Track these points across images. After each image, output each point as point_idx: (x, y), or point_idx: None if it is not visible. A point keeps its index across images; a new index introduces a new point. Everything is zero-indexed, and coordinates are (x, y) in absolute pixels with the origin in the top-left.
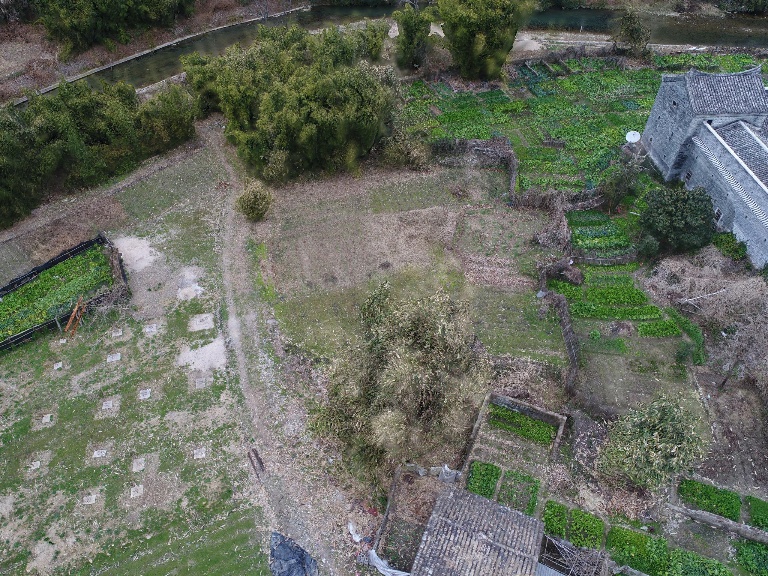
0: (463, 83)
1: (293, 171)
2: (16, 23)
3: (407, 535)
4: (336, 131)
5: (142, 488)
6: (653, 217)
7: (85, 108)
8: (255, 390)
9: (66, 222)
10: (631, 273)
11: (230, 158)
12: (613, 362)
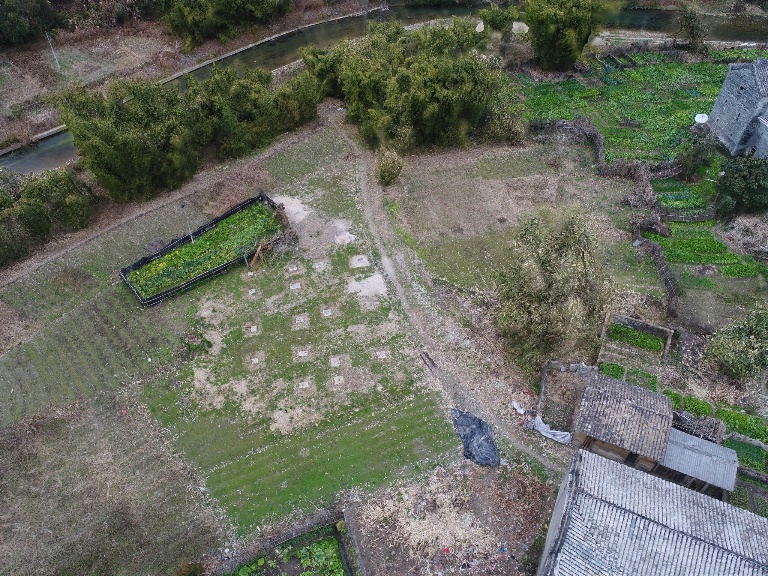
0: (542, 73)
1: (410, 145)
2: (138, 20)
3: (559, 411)
4: (453, 109)
5: (342, 378)
6: (730, 181)
7: (236, 90)
8: (416, 310)
9: (226, 184)
10: (710, 228)
11: (351, 135)
12: (703, 295)
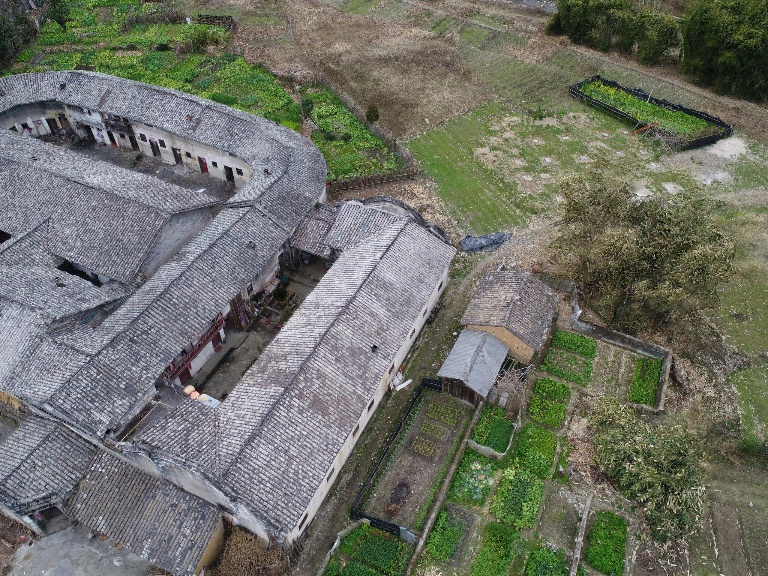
0: None
1: None
2: None
3: None
4: None
5: (530, 179)
6: None
7: None
8: None
9: None
10: None
11: None
12: None
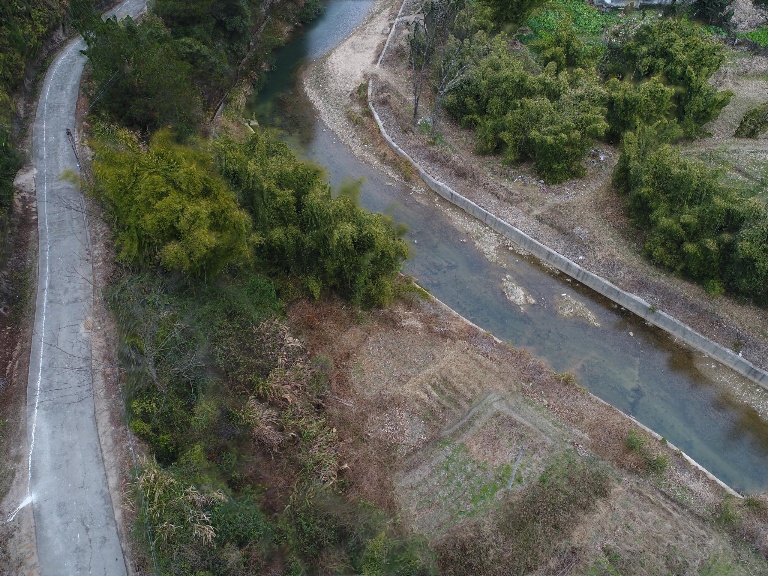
0: None
1: None
2: None
3: None
4: None
5: None
6: (719, 3)
7: None
8: None
9: None
10: None
11: None
12: None
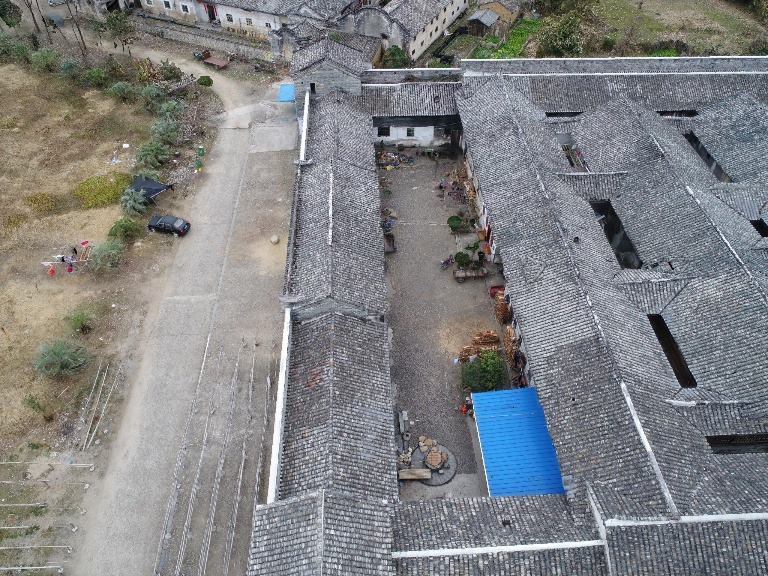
0: None
1: None
2: None
3: None
4: None
5: None
6: None
7: None
8: None
9: None
10: None
11: None
12: None
